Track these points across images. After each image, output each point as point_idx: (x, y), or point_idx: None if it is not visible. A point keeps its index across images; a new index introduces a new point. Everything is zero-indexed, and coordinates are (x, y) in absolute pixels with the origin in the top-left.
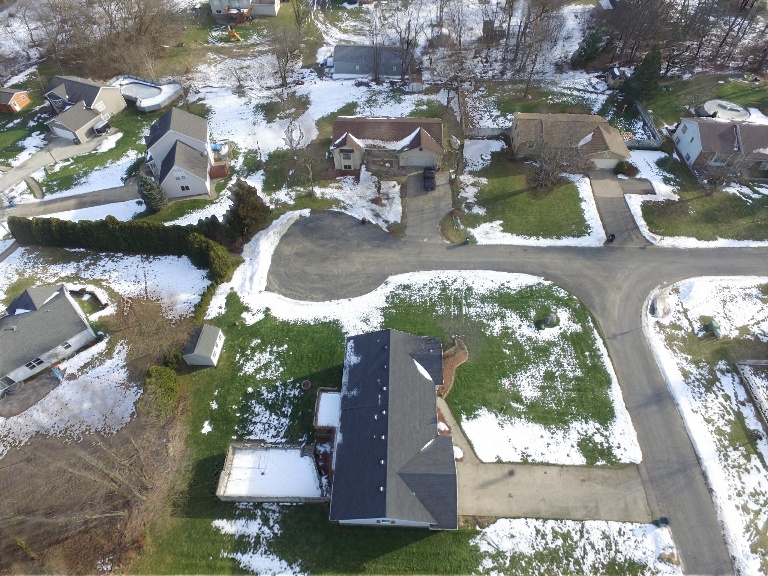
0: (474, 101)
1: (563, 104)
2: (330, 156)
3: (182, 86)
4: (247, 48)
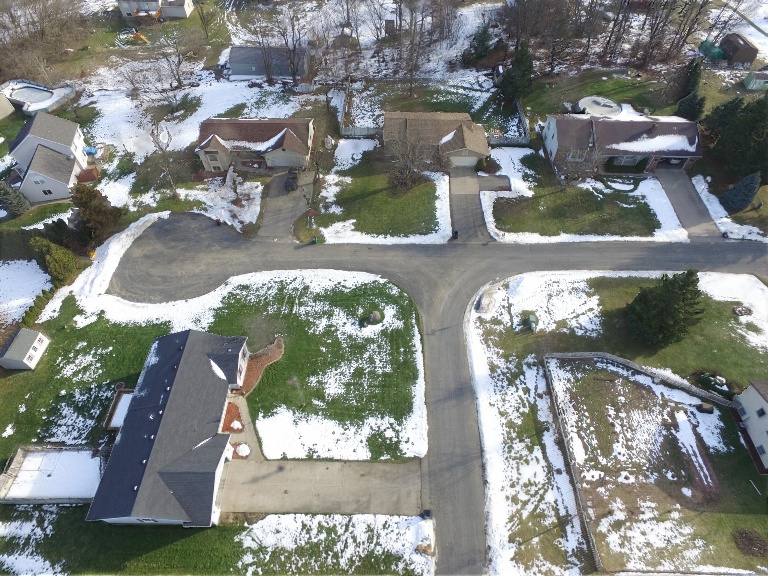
0: (360, 101)
1: (446, 102)
2: None
3: (74, 90)
4: (152, 50)
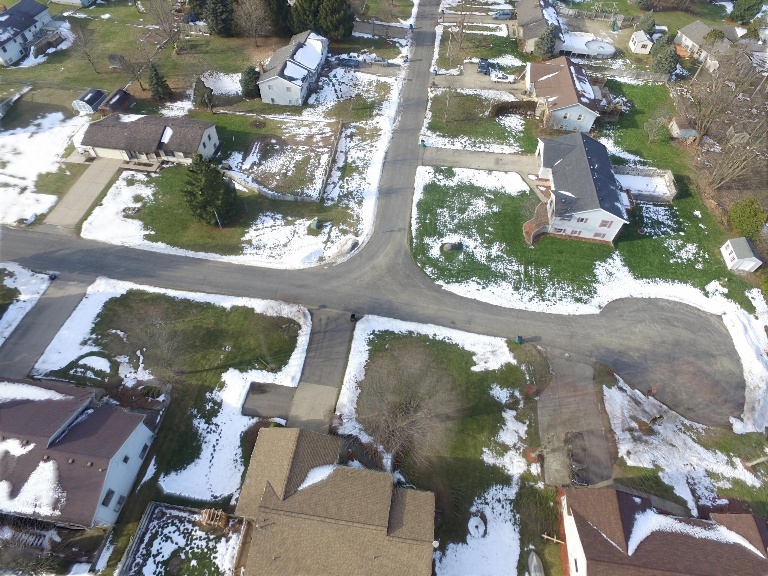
0: None
1: None
2: None
3: None
4: None
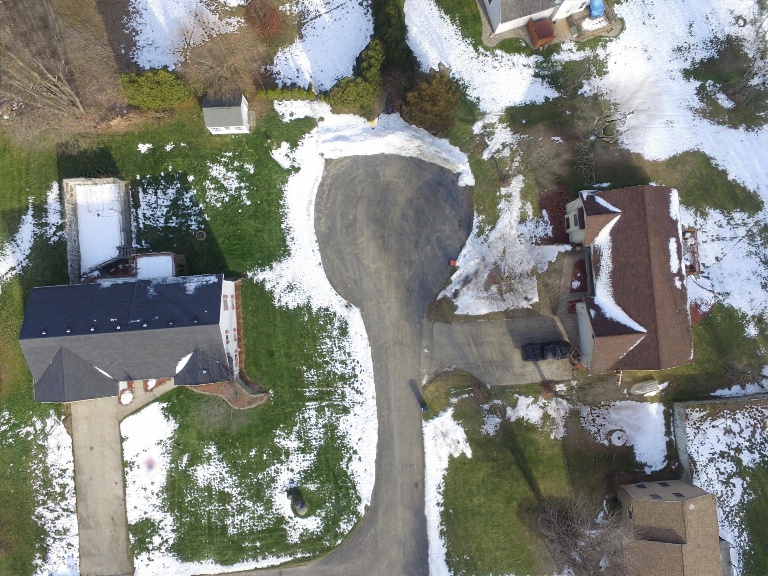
0: None
1: None
2: None
3: None
4: None
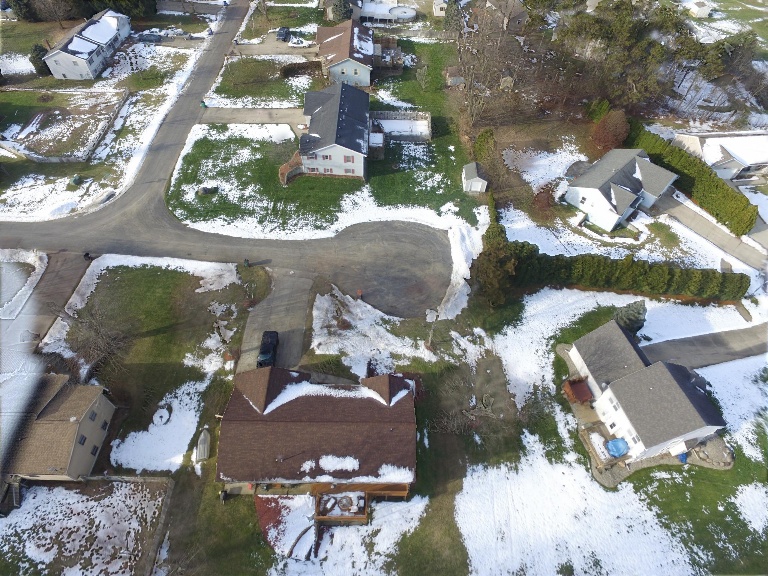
0: None
1: None
2: (420, 434)
3: None
4: None
